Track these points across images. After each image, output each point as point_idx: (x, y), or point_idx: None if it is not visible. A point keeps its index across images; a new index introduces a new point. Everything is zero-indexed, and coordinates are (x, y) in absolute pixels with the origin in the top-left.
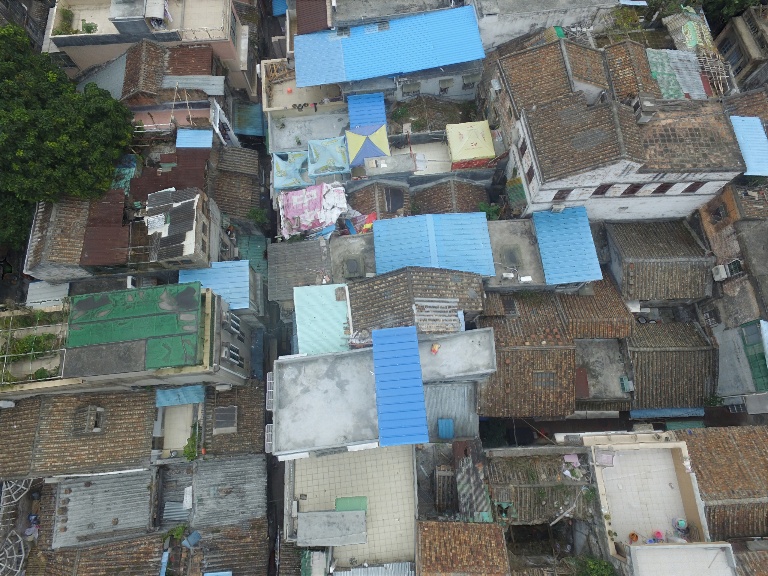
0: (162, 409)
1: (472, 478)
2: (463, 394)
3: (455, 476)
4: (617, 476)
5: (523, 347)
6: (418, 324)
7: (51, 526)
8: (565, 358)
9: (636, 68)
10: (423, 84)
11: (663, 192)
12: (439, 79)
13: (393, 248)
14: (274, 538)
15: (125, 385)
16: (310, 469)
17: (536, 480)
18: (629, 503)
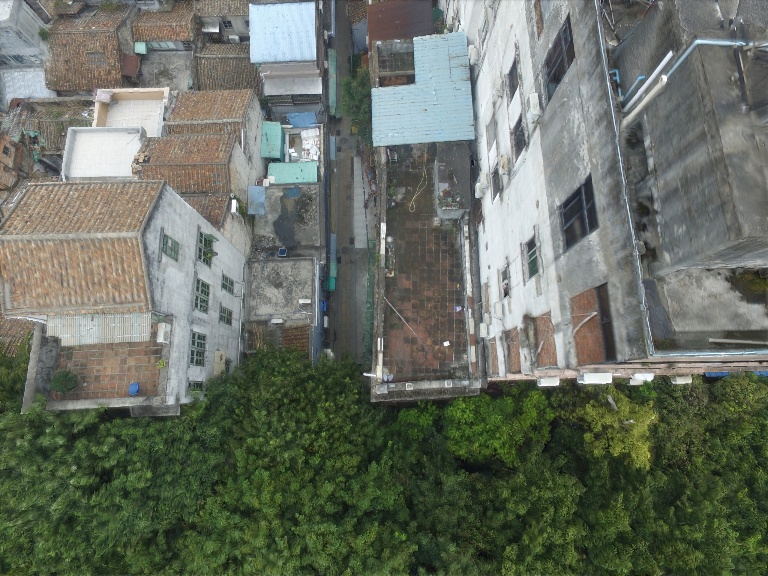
0: None
1: (15, 119)
2: None
3: None
4: (124, 118)
5: (75, 30)
6: None
7: None
8: (109, 40)
9: None
10: None
11: None
12: None
13: None
14: None
15: None
16: None
17: (59, 118)
18: None
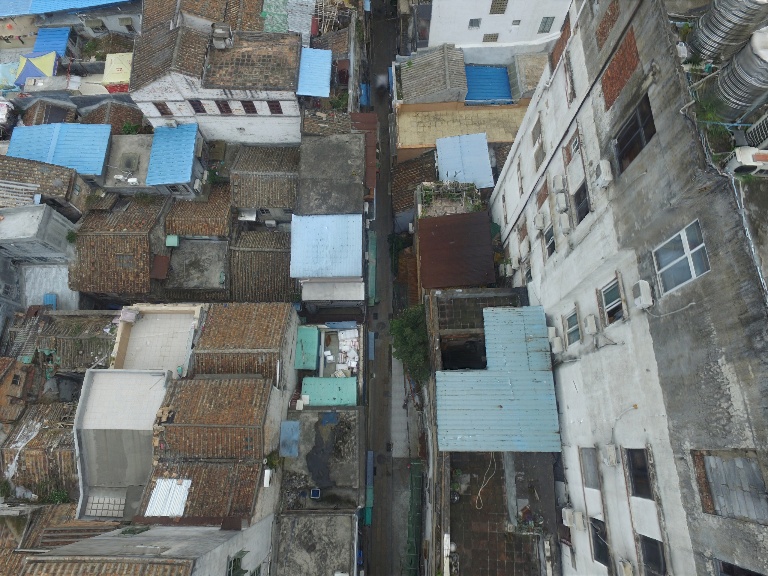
0: None
1: (31, 332)
2: None
3: None
4: (149, 335)
5: (105, 232)
6: None
7: None
8: (141, 243)
9: (241, 6)
10: (106, 21)
11: (256, 112)
12: (118, 17)
13: (22, 149)
14: None
15: None
16: None
17: (78, 334)
18: (150, 355)
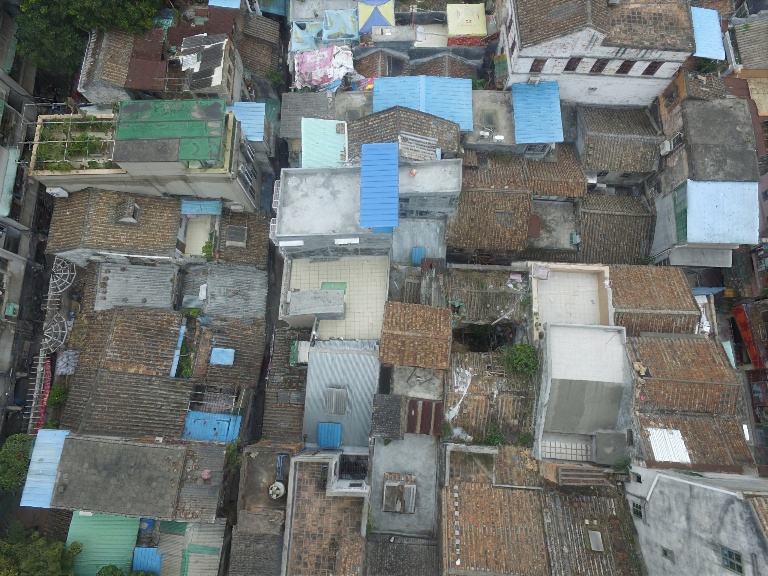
0: (185, 222)
1: (433, 284)
2: (435, 229)
3: (420, 283)
4: (551, 292)
5: (488, 189)
6: (401, 151)
7: (94, 295)
8: (522, 201)
9: None
10: None
11: (626, 73)
12: None
13: (389, 101)
14: (269, 348)
15: (158, 189)
16: (304, 271)
17: (484, 288)
18: (557, 311)
